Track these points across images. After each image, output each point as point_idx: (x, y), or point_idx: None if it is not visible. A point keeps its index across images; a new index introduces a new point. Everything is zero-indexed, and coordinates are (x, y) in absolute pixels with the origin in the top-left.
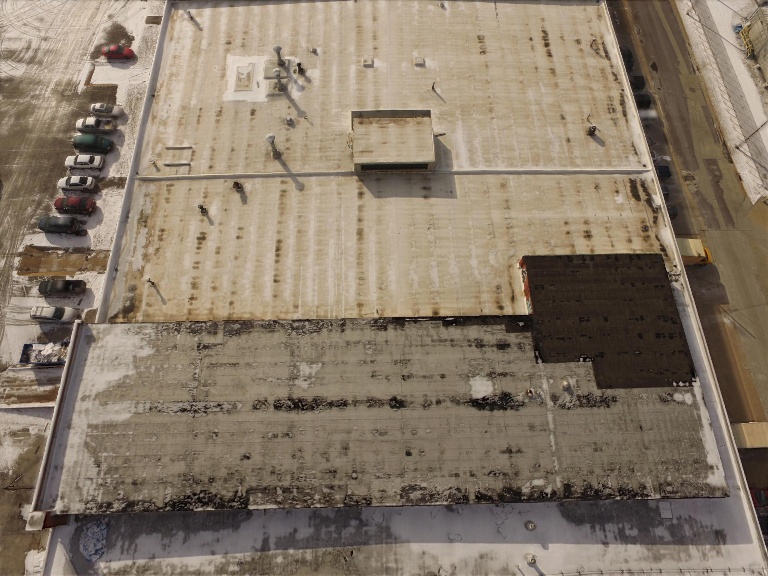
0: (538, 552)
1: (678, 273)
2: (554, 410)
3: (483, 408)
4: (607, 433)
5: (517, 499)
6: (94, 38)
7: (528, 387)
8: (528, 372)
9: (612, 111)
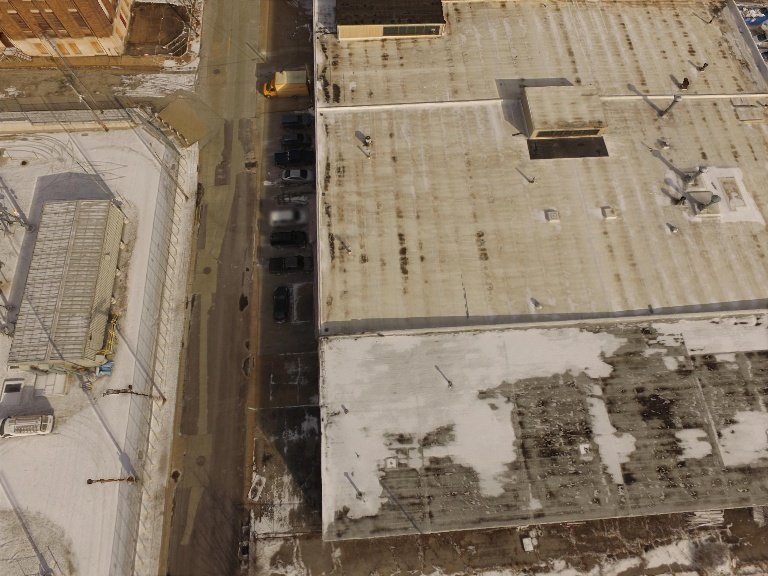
0: None
1: (318, 33)
2: None
3: None
4: None
5: None
6: None
7: None
8: None
9: (341, 169)
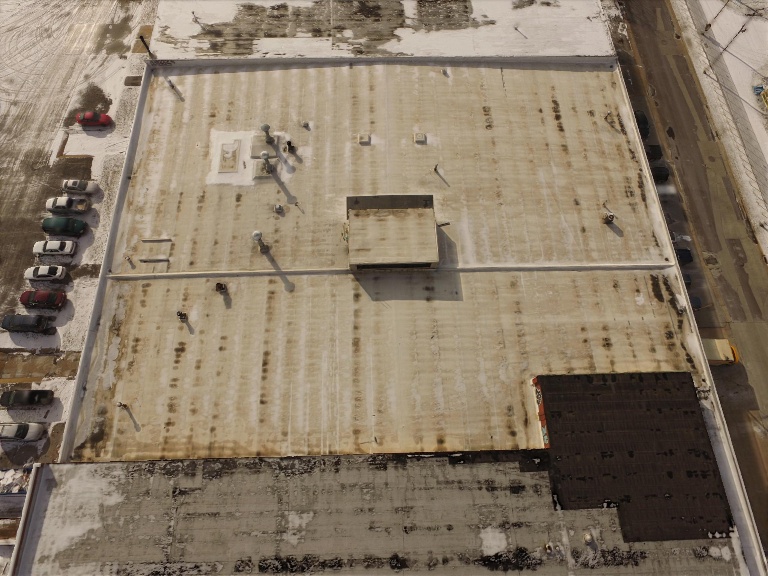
0: None
1: (707, 389)
2: (576, 569)
3: (496, 568)
4: None
5: None
6: (68, 102)
7: (546, 540)
8: (546, 521)
9: (630, 195)
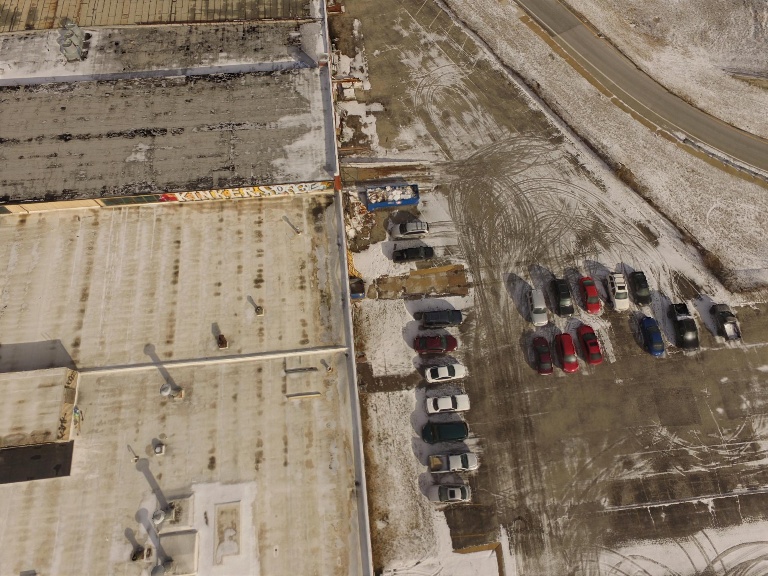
0: None
1: None
2: None
3: None
4: None
5: None
6: None
7: None
8: None
9: None
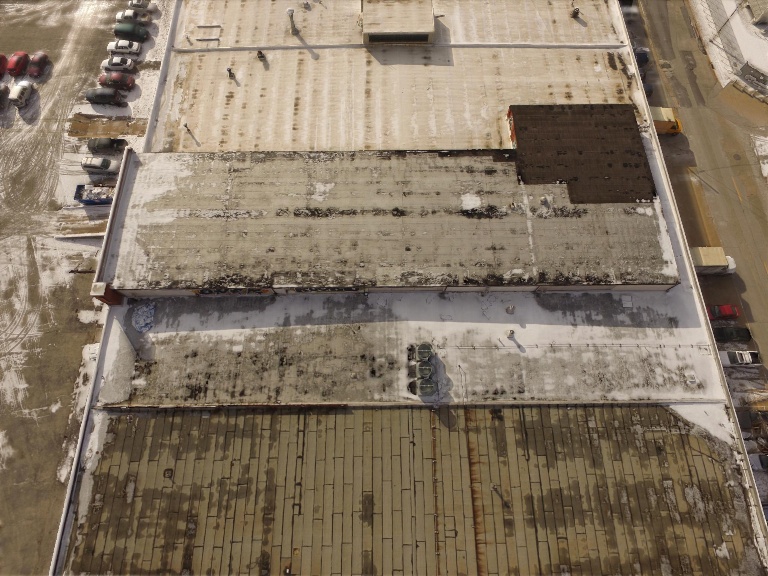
0: (517, 330)
1: (647, 126)
2: (533, 219)
3: (472, 217)
4: (578, 236)
5: (499, 283)
6: None
7: (511, 202)
8: (511, 191)
9: None
